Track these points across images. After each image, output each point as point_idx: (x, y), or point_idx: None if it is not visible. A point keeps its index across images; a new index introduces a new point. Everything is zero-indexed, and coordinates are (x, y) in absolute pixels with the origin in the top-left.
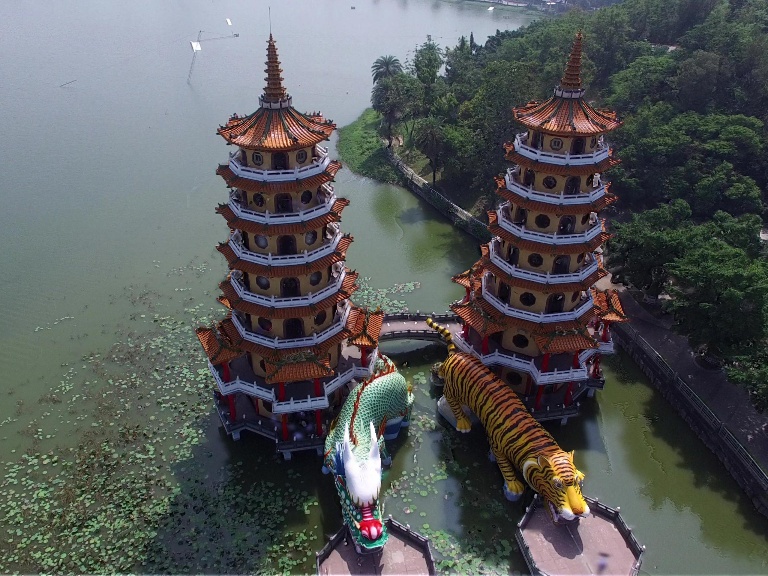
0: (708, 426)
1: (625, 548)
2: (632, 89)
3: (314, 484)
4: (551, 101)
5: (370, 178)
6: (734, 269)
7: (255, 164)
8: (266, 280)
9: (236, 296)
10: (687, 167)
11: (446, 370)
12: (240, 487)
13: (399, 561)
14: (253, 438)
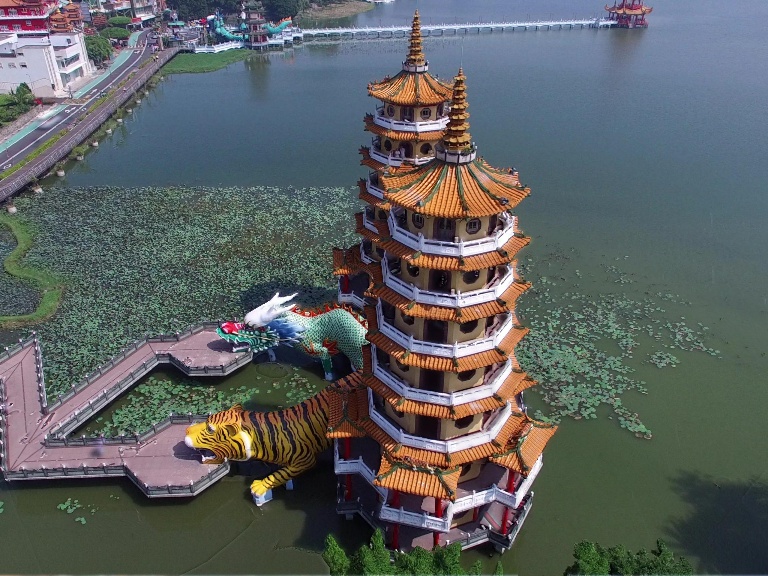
0: None
1: None
2: None
3: None
4: None
5: None
6: None
7: None
8: None
9: None
10: None
11: None
12: None
13: (221, 359)
14: None
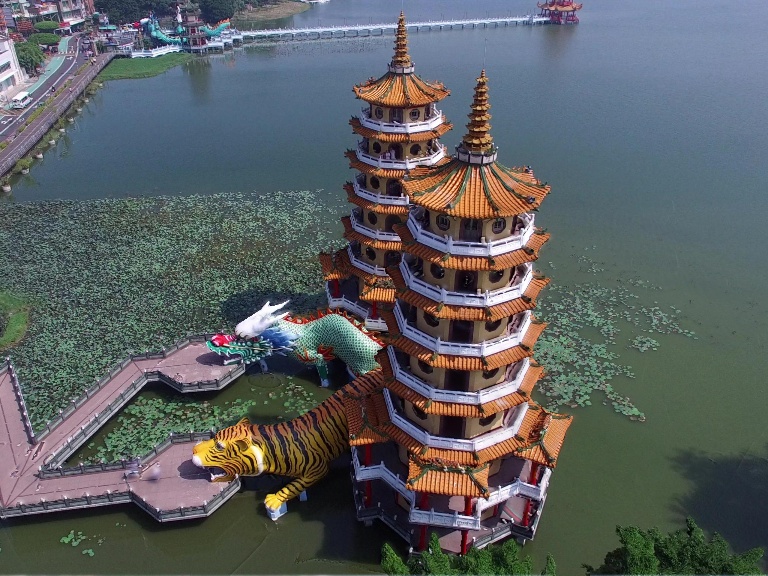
0: None
1: None
2: None
3: None
4: None
5: None
6: None
7: None
8: None
9: None
10: None
11: None
12: None
13: (213, 373)
14: None
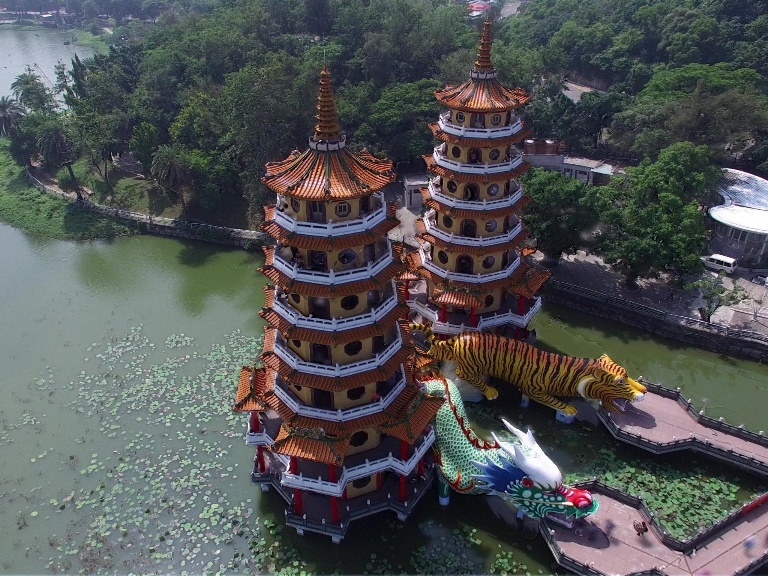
0: (597, 302)
1: (664, 399)
2: (307, 78)
3: (446, 520)
4: (476, 84)
5: (93, 239)
6: (566, 185)
7: (339, 217)
8: (358, 343)
9: (325, 379)
10: (419, 129)
11: (463, 354)
12: (404, 573)
13: None
14: (356, 526)
